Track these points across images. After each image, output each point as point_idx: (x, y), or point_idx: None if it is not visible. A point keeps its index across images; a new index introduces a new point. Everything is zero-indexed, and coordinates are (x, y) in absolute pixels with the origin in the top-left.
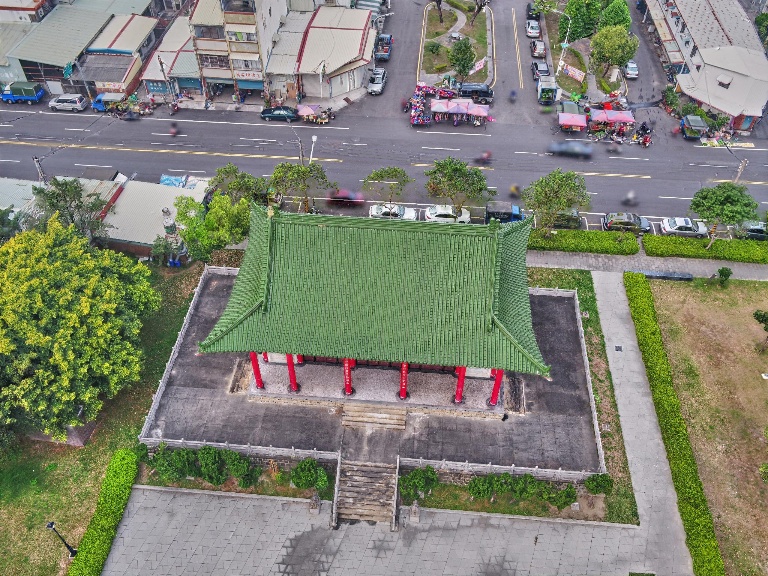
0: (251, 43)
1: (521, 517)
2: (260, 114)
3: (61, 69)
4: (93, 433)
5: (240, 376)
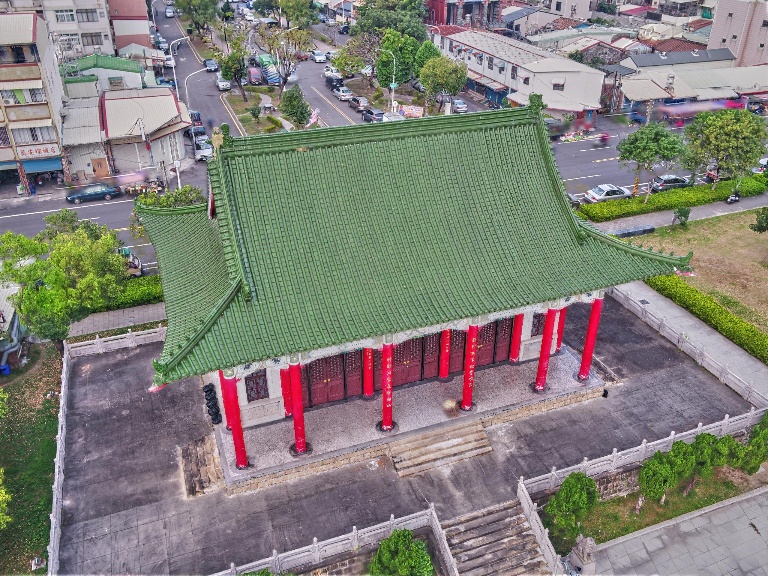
0: (38, 105)
1: (713, 507)
2: (64, 200)
3: None
4: None
5: (196, 467)
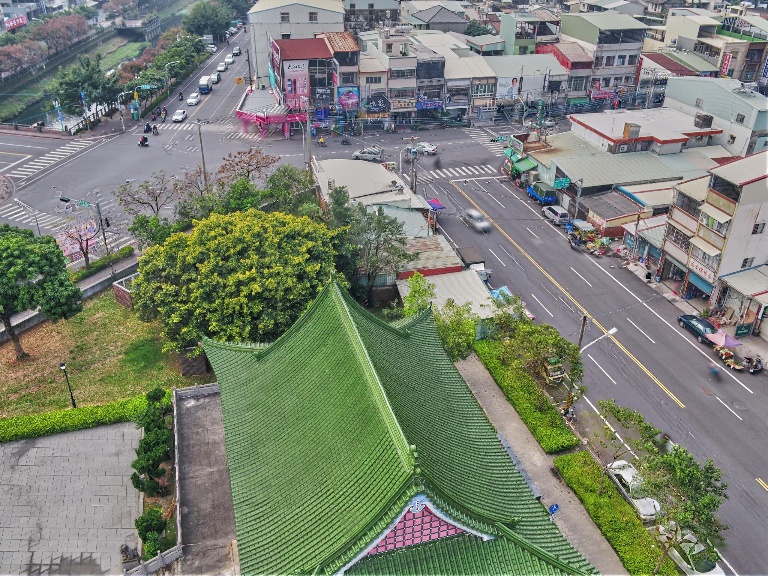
0: (719, 235)
1: None
2: None
3: (576, 187)
4: (197, 375)
5: None
